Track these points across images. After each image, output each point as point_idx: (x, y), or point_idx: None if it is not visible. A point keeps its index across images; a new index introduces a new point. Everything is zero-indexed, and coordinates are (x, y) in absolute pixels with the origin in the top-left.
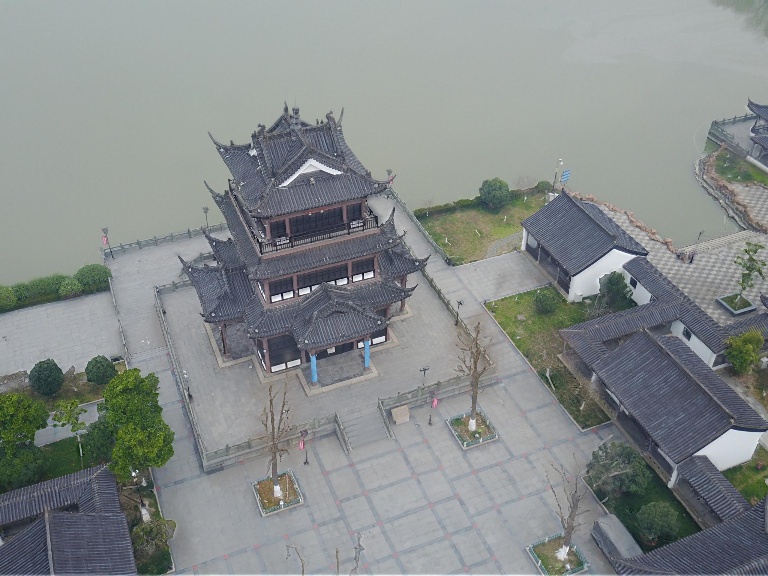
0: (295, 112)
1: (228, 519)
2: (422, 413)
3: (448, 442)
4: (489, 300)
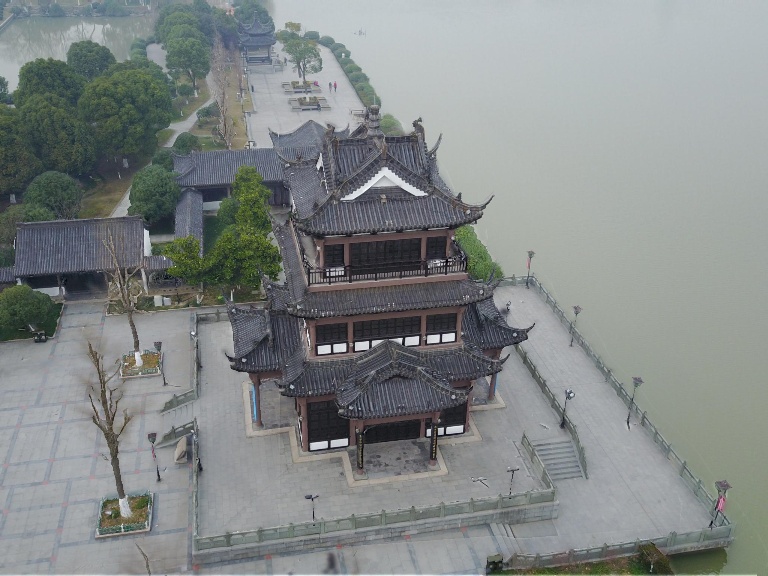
0: None
1: None
2: (181, 476)
3: None
4: None
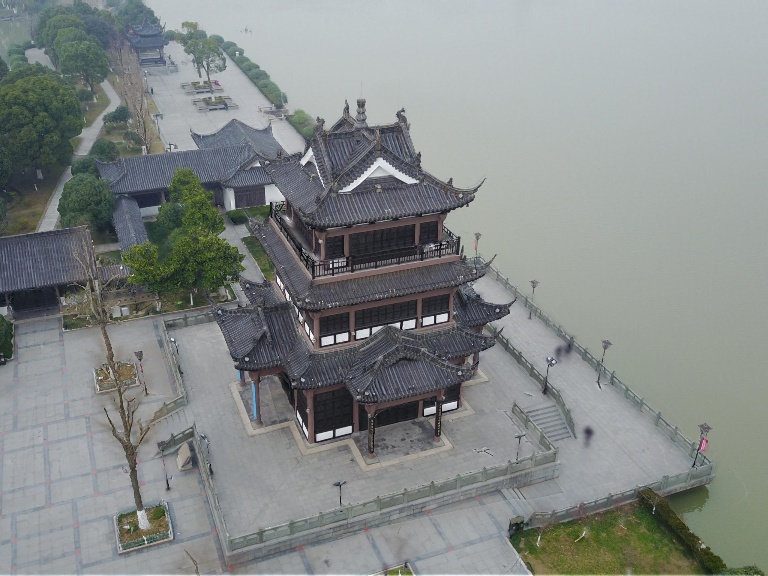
0: (358, 105)
1: (102, 353)
2: (190, 482)
3: (134, 503)
4: (419, 575)
